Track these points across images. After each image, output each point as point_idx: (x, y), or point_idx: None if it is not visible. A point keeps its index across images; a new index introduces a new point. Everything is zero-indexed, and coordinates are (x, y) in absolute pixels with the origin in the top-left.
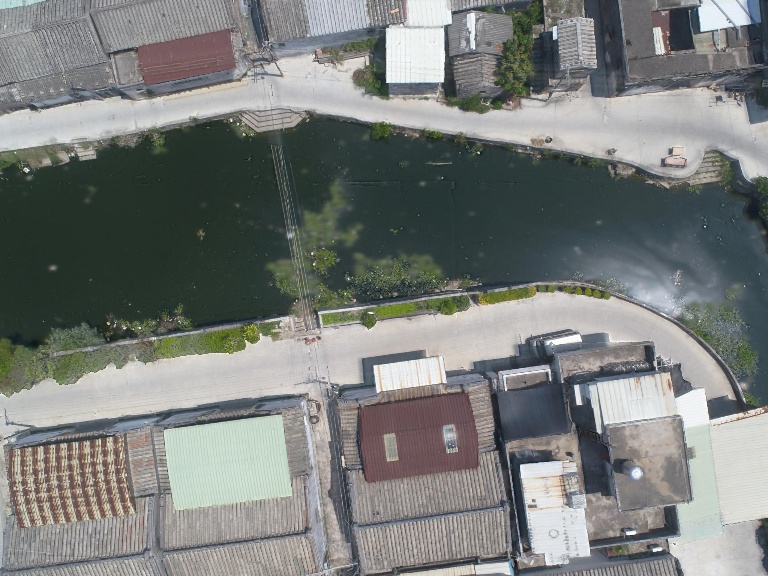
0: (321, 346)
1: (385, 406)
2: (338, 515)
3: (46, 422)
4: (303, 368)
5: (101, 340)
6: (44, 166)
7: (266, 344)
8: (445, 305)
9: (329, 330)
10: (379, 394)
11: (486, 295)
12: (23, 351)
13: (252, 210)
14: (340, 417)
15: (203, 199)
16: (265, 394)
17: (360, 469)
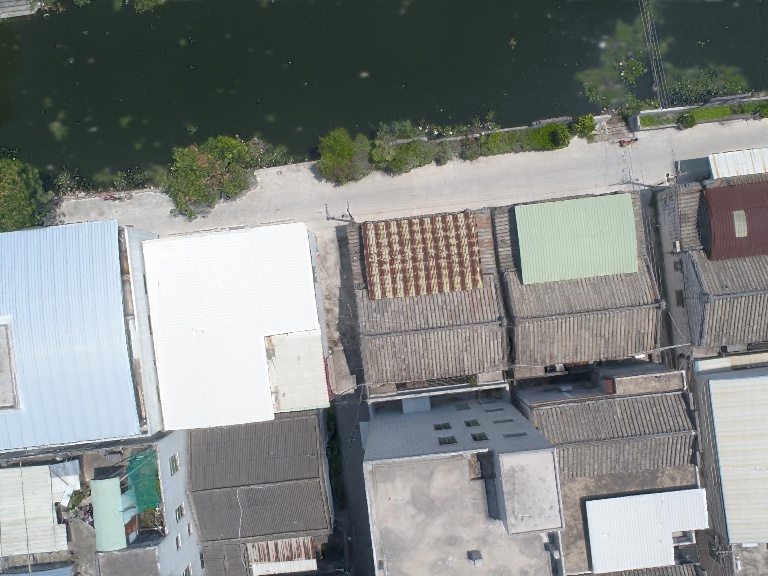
0: (635, 149)
1: (730, 187)
2: None
3: (366, 218)
4: (617, 170)
5: None
6: None
7: (581, 146)
8: (764, 107)
9: (643, 133)
10: (718, 179)
11: None
12: (363, 138)
13: (563, 20)
14: (678, 202)
15: (515, 9)
16: (580, 194)
17: (701, 249)
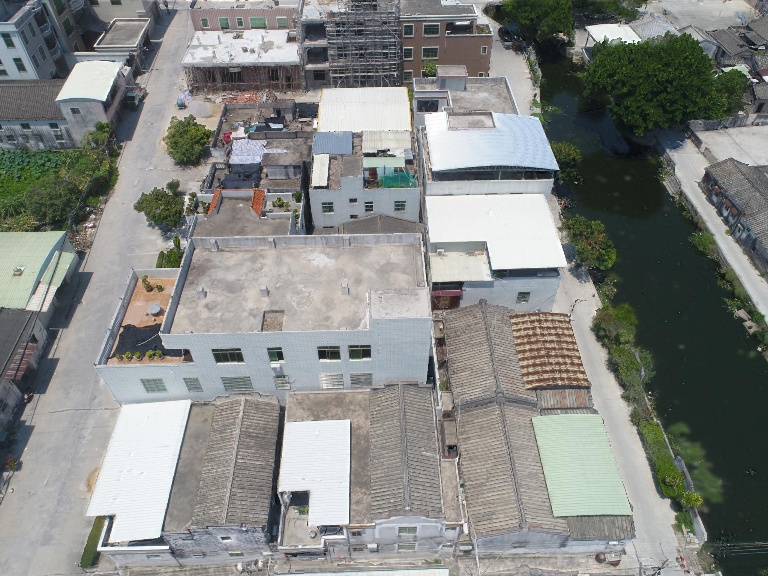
0: (678, 574)
1: None
2: (503, 572)
3: None
4: (651, 552)
5: None
6: (767, 361)
7: (667, 518)
8: None
9: None
10: None
11: None
12: (634, 331)
13: None
14: None
15: None
16: None
17: None
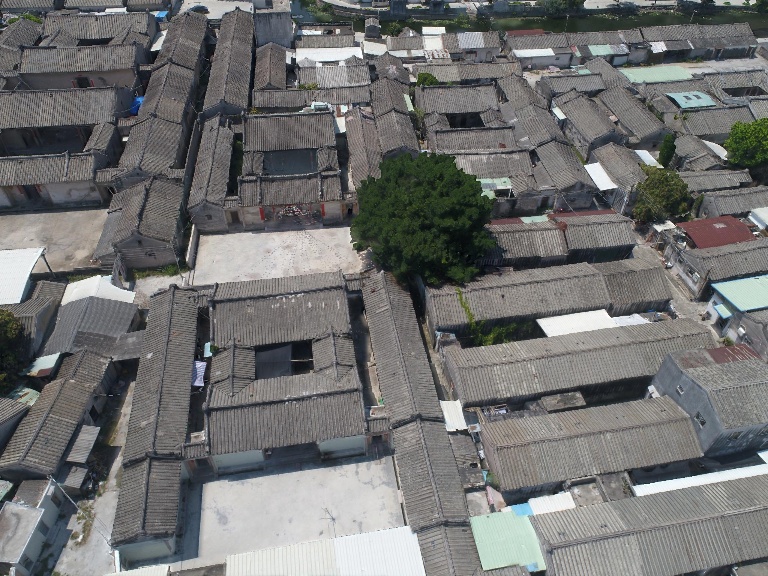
0: None
1: None
2: None
3: None
4: None
5: (546, 8)
6: None
7: None
8: None
9: None
10: None
11: (406, 7)
12: None
13: None
14: None
15: None
16: None
17: None
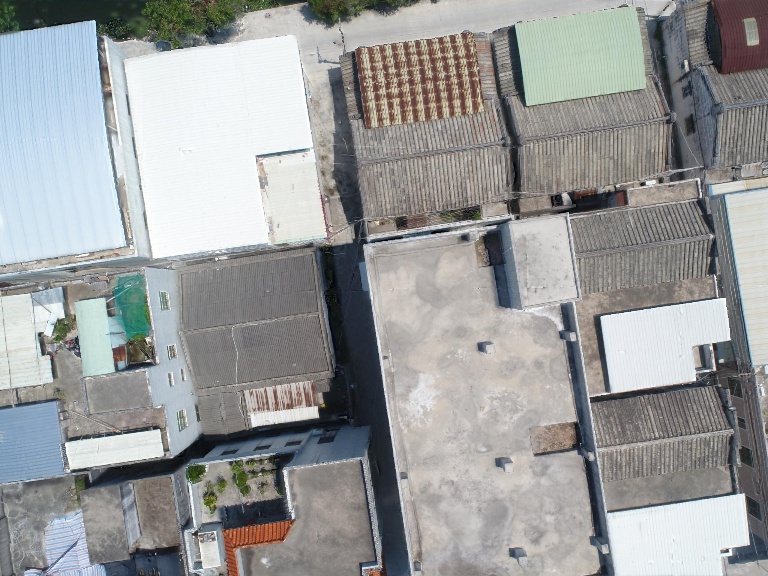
0: None
1: None
2: None
3: None
4: (620, 1)
5: None
6: None
7: None
8: None
9: None
10: None
11: None
12: None
13: None
14: (685, 18)
15: None
16: None
17: (711, 65)
